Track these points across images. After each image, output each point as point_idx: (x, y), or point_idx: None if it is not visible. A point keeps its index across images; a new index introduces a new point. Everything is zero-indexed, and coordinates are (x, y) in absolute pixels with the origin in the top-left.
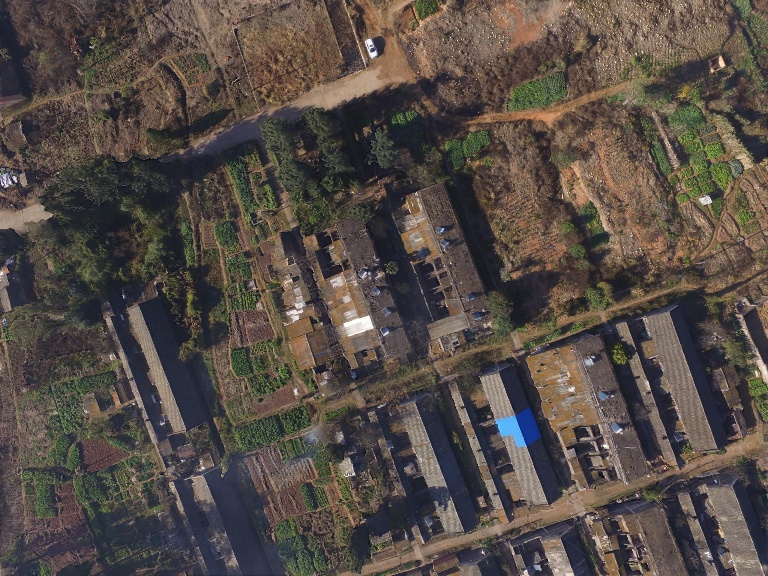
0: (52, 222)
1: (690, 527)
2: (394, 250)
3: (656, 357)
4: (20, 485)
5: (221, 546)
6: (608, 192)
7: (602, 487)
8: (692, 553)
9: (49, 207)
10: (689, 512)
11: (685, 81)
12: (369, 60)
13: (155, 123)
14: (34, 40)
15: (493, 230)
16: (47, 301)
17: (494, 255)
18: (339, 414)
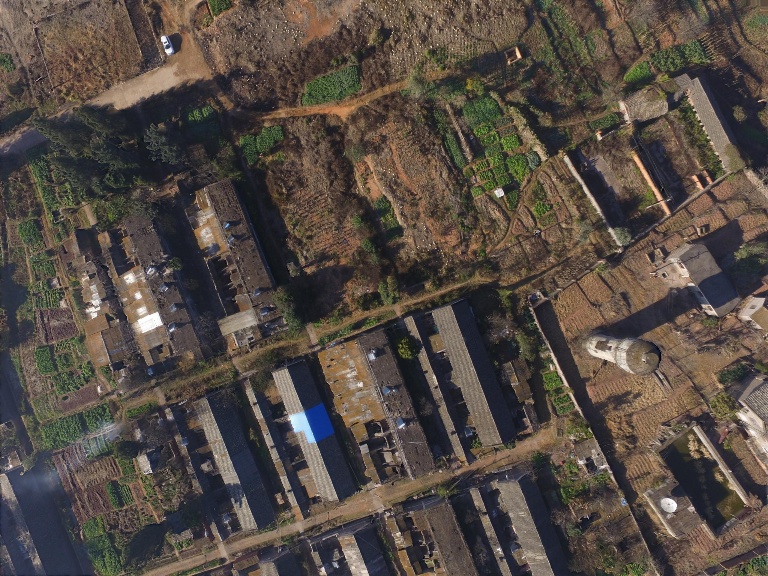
0: None
1: (482, 523)
2: None
3: (444, 351)
4: None
5: (27, 544)
6: (401, 186)
7: (400, 483)
8: (481, 549)
9: None
10: (480, 508)
11: (481, 73)
12: (166, 57)
13: None
14: None
15: (287, 225)
16: None
17: (289, 250)
18: (141, 411)
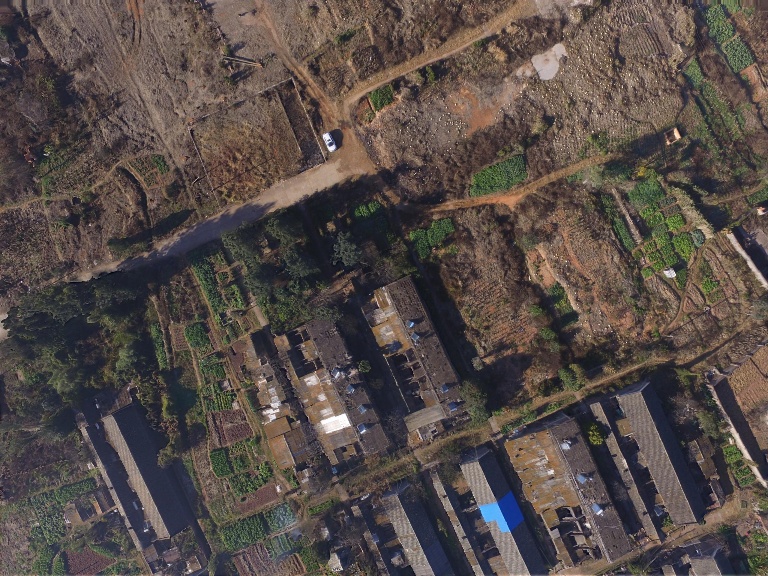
0: (18, 339)
1: None
2: (366, 341)
3: (631, 434)
4: None
5: None
6: (574, 272)
7: (588, 562)
8: None
9: (12, 332)
10: None
11: (642, 155)
12: (328, 153)
13: (117, 227)
14: None
15: (463, 317)
16: (20, 413)
17: (466, 341)
18: (323, 508)
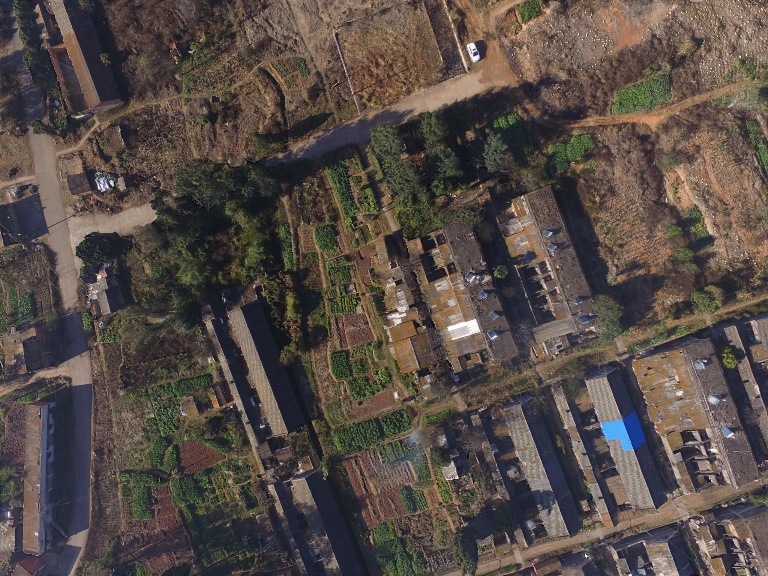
0: (156, 226)
1: None
2: (495, 254)
3: (765, 361)
4: (115, 487)
5: (321, 549)
6: (713, 195)
7: (706, 491)
8: None
9: (161, 211)
10: None
11: None
12: (471, 64)
13: (253, 127)
14: (132, 45)
15: (597, 234)
16: (144, 304)
17: (598, 259)
18: (440, 417)
